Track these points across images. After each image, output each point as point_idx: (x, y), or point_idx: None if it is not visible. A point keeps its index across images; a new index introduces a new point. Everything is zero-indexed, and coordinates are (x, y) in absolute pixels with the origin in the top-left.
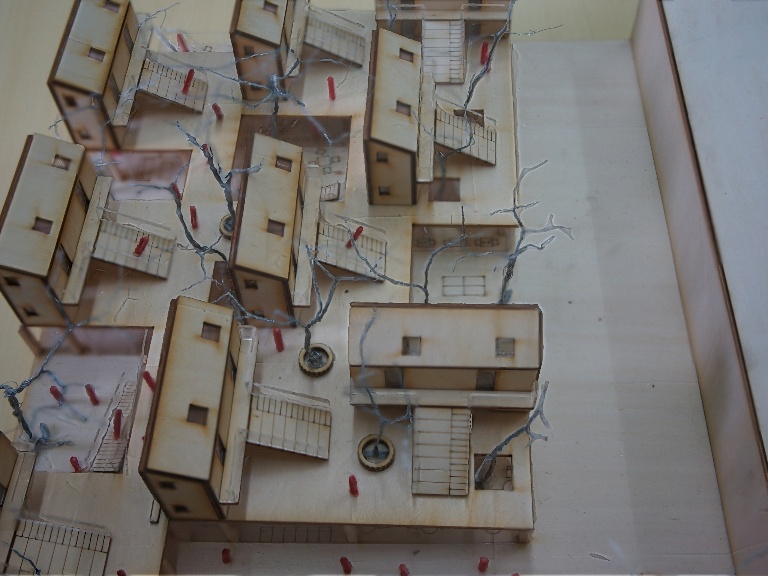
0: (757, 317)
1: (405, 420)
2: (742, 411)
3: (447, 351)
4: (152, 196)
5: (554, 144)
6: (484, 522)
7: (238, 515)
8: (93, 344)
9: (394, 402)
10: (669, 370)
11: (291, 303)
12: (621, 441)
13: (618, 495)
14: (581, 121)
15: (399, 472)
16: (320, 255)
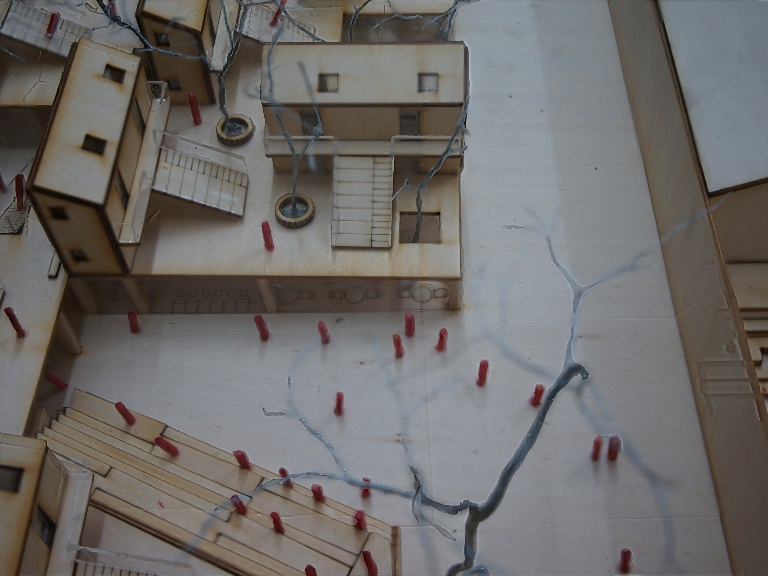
0: (698, 61)
1: (327, 182)
2: (682, 150)
3: (366, 87)
4: None
5: None
6: (408, 272)
7: (143, 269)
8: (3, 133)
9: (312, 151)
10: (613, 154)
11: (207, 67)
12: (561, 218)
13: None
14: None
15: (319, 229)
16: None
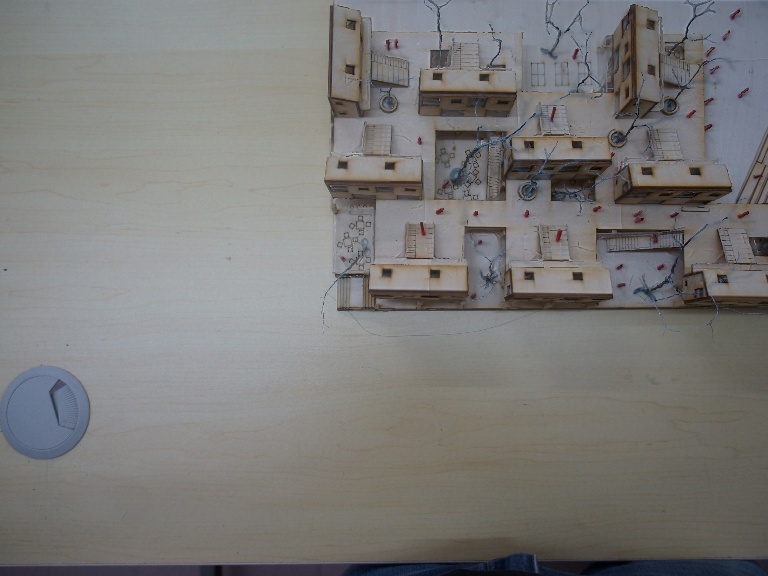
0: None
1: None
2: None
3: (653, 53)
4: (475, 261)
5: (430, 19)
6: (701, 56)
7: None
8: None
9: None
10: None
11: None
12: None
13: (660, 4)
14: (411, 2)
15: None
16: (567, 133)
